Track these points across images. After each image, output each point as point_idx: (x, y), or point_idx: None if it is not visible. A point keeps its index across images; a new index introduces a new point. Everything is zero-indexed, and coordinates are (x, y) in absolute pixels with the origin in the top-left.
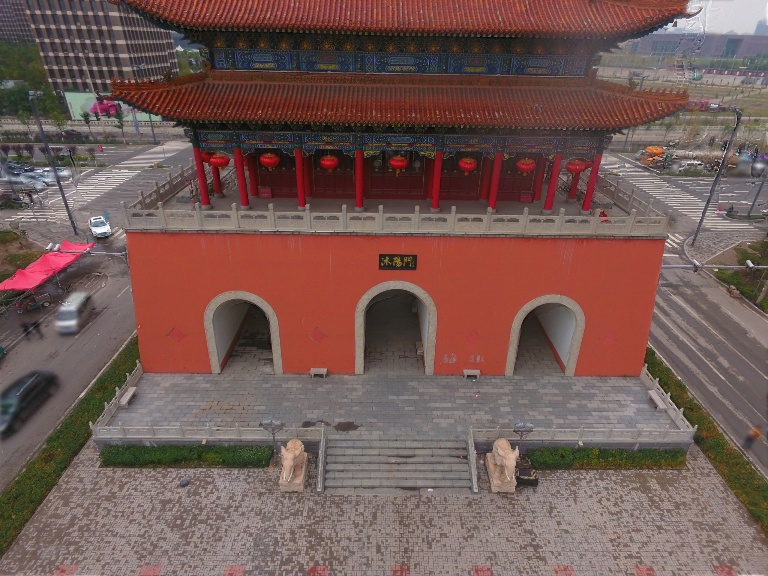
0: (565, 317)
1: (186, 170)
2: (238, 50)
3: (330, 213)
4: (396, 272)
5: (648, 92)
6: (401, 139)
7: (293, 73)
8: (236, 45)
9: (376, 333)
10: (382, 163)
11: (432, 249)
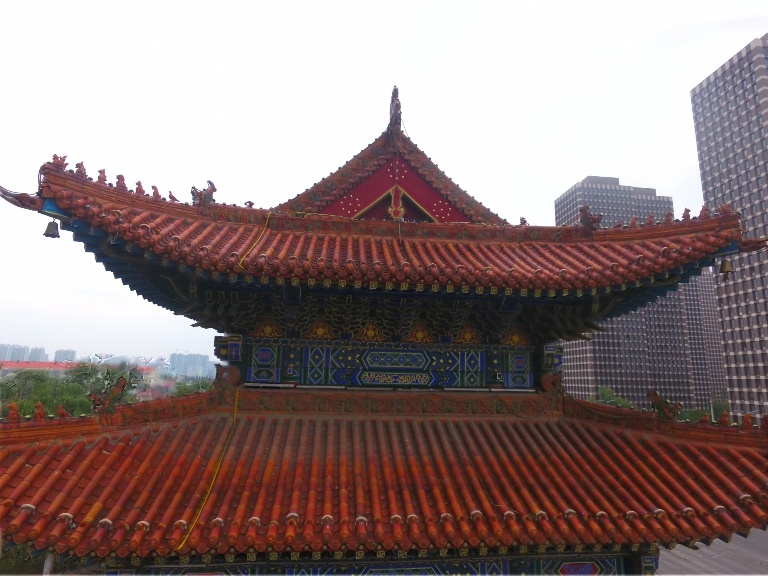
0: None
1: None
2: None
3: None
4: None
5: (45, 418)
6: None
7: None
8: None
9: None
10: None
11: None
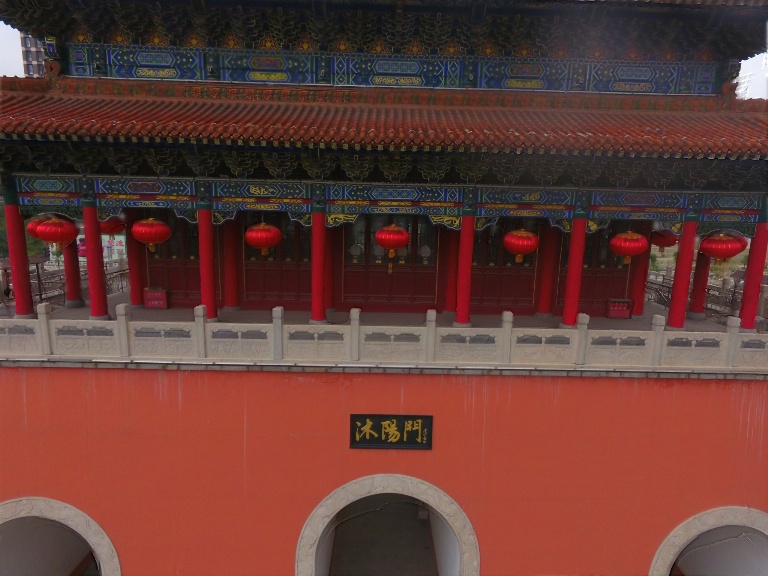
0: (740, 549)
1: (55, 273)
2: (113, 47)
3: (248, 324)
4: (387, 454)
5: None
6: (397, 193)
7: (206, 83)
8: (111, 40)
9: (351, 570)
10: (364, 249)
11: (465, 403)
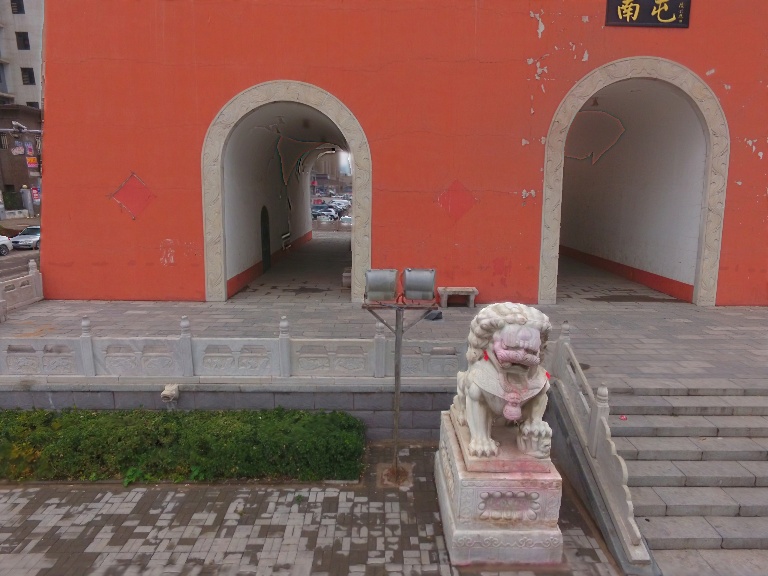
0: None
1: None
2: None
3: None
4: None
5: None
6: None
7: None
8: None
9: None
10: None
11: None
